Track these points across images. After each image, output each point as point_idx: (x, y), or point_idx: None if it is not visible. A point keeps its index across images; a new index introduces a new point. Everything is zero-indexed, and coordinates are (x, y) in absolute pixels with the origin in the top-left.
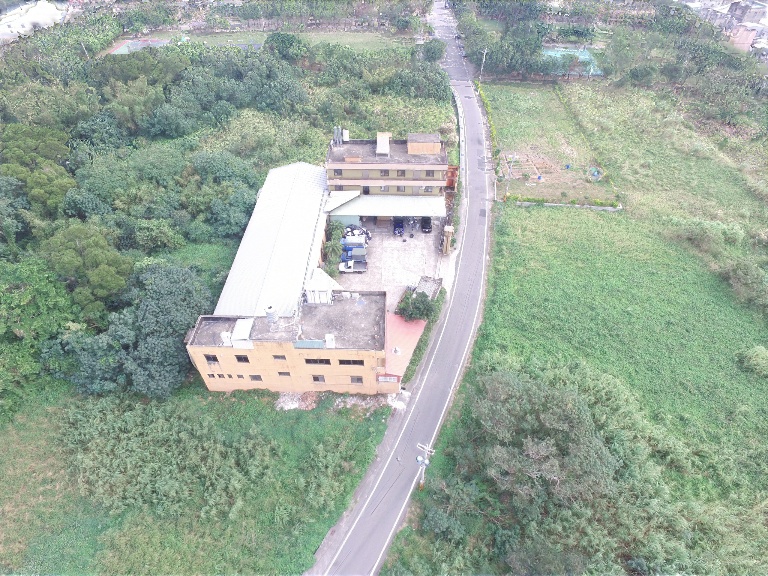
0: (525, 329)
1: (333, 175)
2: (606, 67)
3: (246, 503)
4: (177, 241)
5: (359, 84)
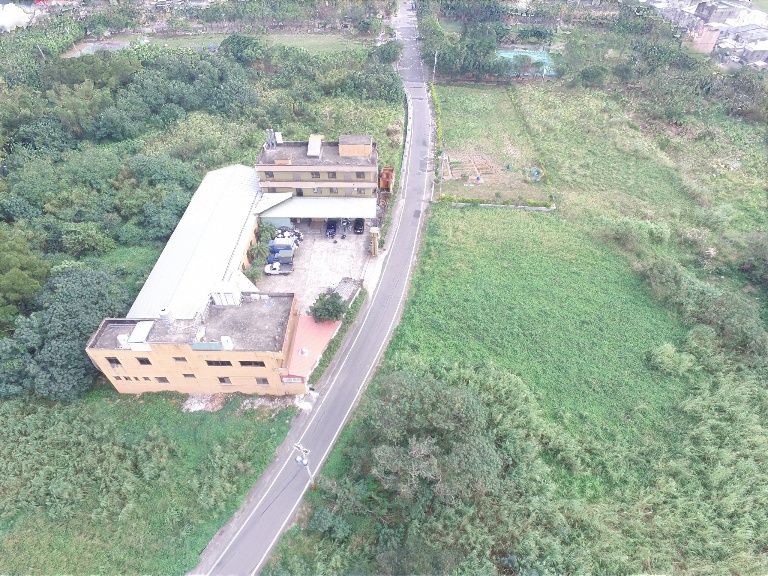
0: (440, 329)
1: (265, 177)
2: (559, 68)
3: (139, 505)
4: (106, 244)
5: (310, 86)
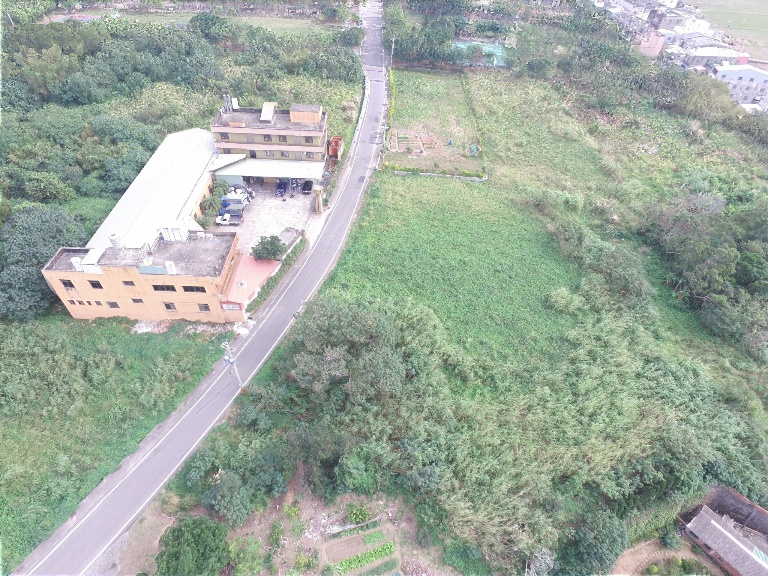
0: (370, 273)
1: (220, 139)
2: None
3: (87, 405)
4: (68, 194)
5: (274, 64)
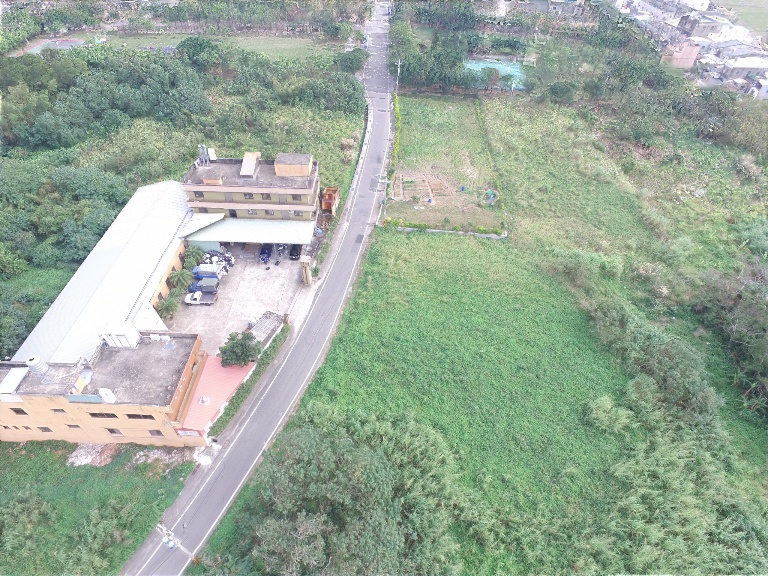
0: (364, 373)
1: (194, 197)
2: (528, 82)
3: None
4: (17, 266)
5: (266, 94)
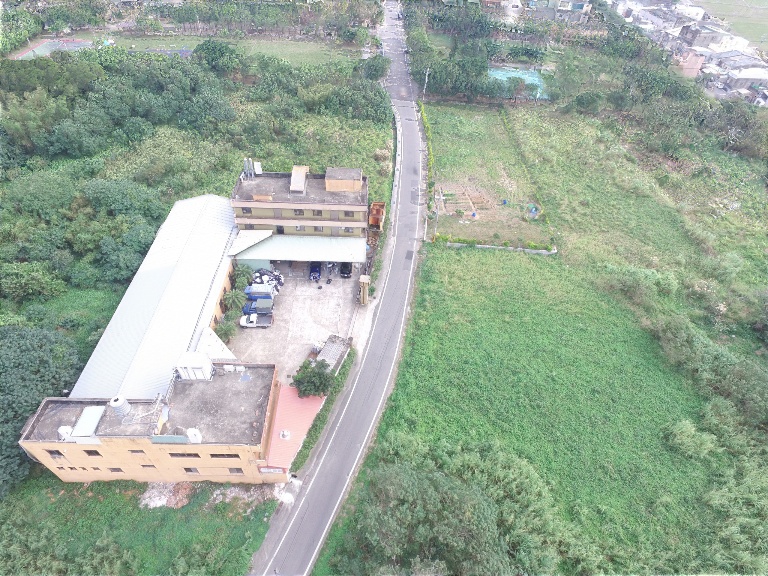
0: (439, 399)
1: (241, 213)
2: (553, 92)
3: None
4: (55, 287)
5: (292, 102)
